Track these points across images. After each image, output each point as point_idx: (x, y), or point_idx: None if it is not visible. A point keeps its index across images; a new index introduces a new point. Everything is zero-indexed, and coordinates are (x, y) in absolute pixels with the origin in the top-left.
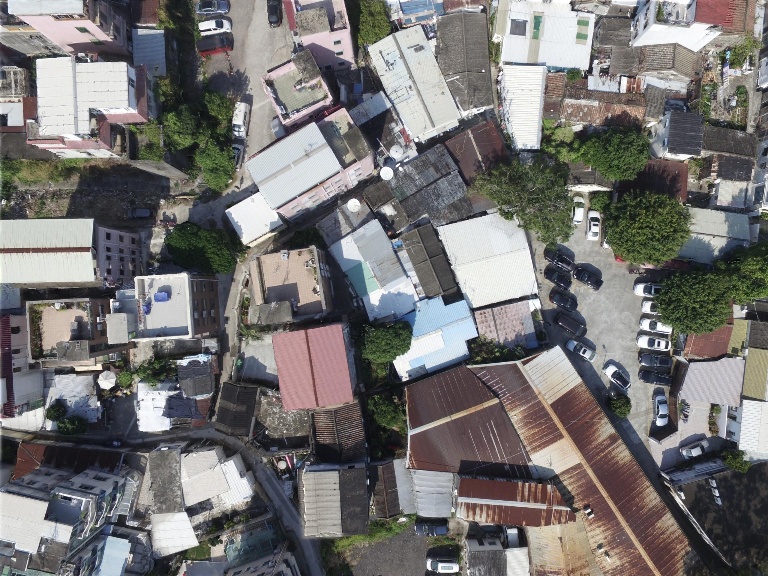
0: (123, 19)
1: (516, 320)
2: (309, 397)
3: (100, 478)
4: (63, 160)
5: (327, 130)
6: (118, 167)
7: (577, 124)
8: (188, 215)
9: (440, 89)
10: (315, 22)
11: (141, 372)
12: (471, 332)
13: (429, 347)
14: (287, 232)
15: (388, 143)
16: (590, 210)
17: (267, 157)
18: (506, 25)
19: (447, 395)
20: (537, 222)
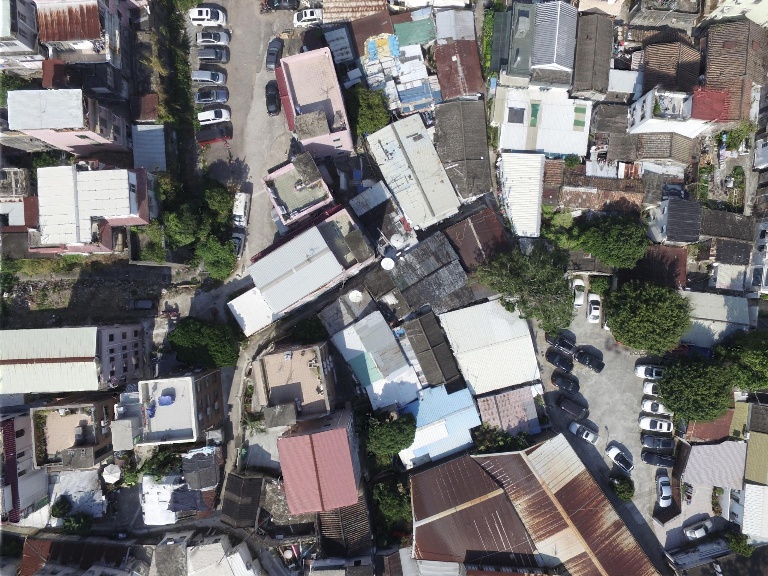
0: (123, 118)
1: (519, 406)
2: (315, 502)
3: (106, 575)
4: (64, 256)
5: (328, 229)
6: (120, 261)
7: (576, 210)
8: (190, 304)
9: (439, 177)
10: (315, 126)
11: (146, 470)
12: (474, 421)
13: (433, 436)
14: (289, 319)
15: (388, 232)
16: (590, 293)
17: (269, 262)
18: (504, 113)
19: (452, 486)
20: (538, 314)
